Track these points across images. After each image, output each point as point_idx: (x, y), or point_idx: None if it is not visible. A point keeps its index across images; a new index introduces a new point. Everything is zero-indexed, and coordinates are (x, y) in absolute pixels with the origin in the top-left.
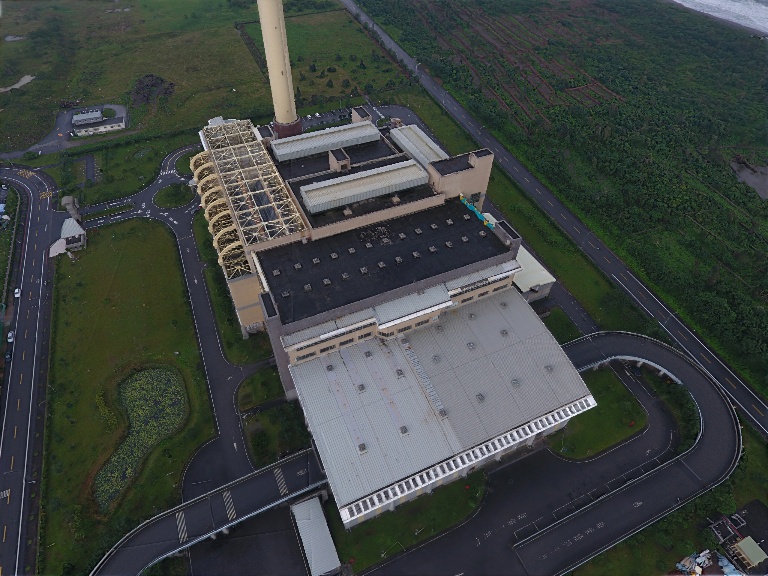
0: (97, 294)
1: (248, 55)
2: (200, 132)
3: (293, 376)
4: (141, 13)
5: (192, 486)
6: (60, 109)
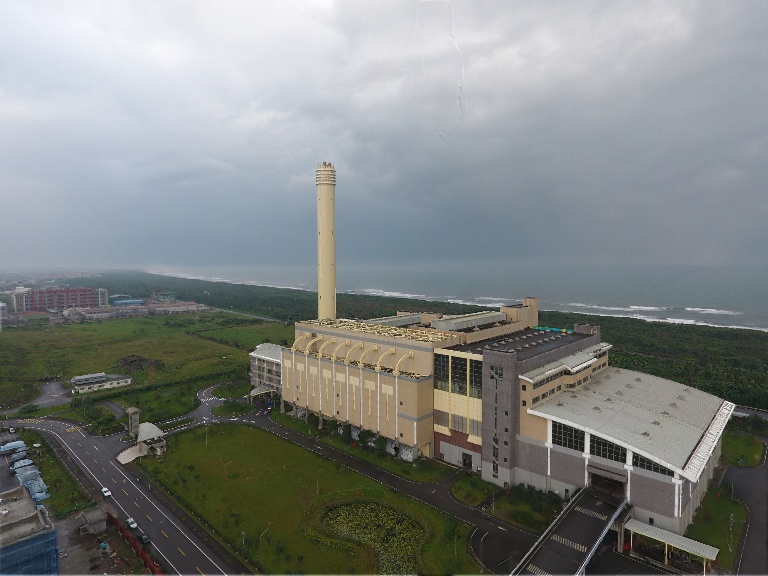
0: (216, 474)
1: (216, 343)
2: (253, 353)
3: (540, 412)
4: (83, 333)
5: (500, 566)
6: (40, 382)
